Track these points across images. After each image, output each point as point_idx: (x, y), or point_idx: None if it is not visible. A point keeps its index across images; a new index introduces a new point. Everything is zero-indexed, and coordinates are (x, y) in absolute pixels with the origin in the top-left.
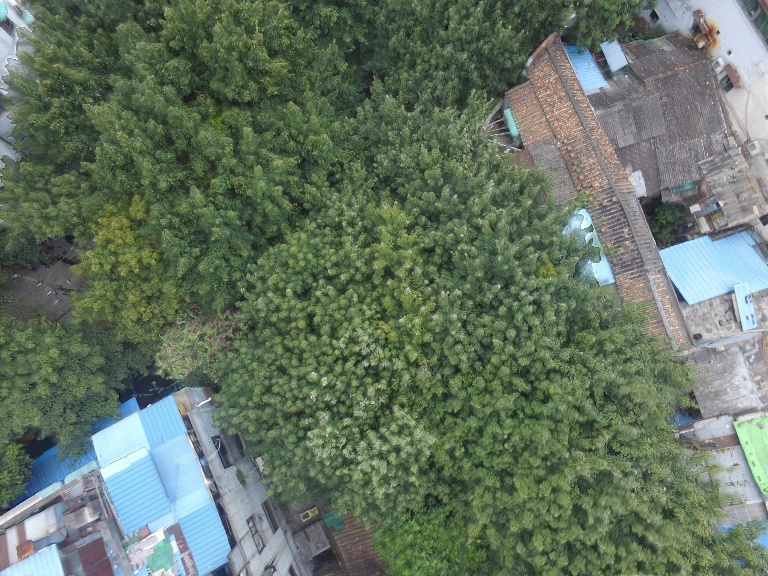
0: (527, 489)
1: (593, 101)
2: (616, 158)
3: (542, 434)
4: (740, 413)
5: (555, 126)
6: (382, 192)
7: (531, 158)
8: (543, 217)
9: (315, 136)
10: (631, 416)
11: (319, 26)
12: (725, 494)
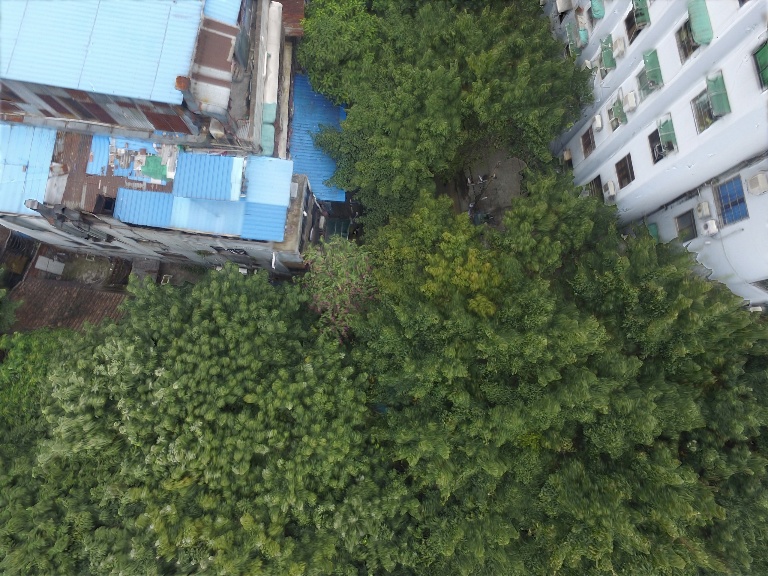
0: None
1: None
2: None
3: None
4: None
5: None
6: (352, 570)
7: None
8: None
9: None
10: None
11: None
12: None
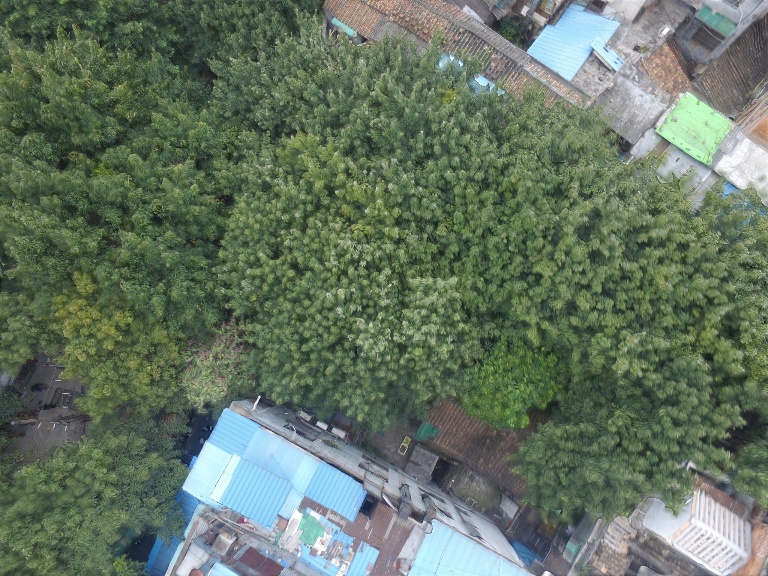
0: (547, 268)
1: None
2: (441, 1)
3: (529, 215)
4: (655, 122)
5: (379, 7)
6: (281, 139)
7: None
8: None
9: (193, 129)
10: (582, 162)
11: (131, 45)
12: (685, 186)
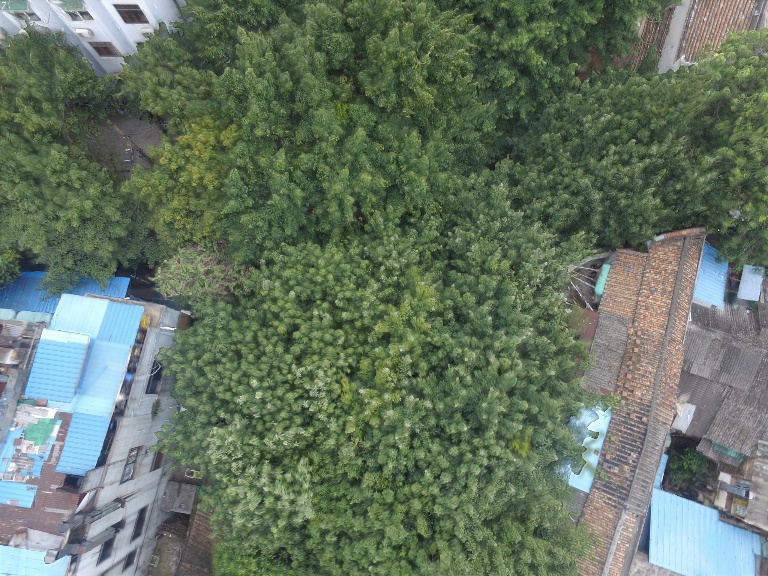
0: None
1: (696, 312)
2: (676, 382)
3: None
4: None
5: (640, 312)
6: (438, 262)
7: (596, 324)
8: (557, 393)
9: (415, 175)
10: None
11: (492, 80)
12: None
